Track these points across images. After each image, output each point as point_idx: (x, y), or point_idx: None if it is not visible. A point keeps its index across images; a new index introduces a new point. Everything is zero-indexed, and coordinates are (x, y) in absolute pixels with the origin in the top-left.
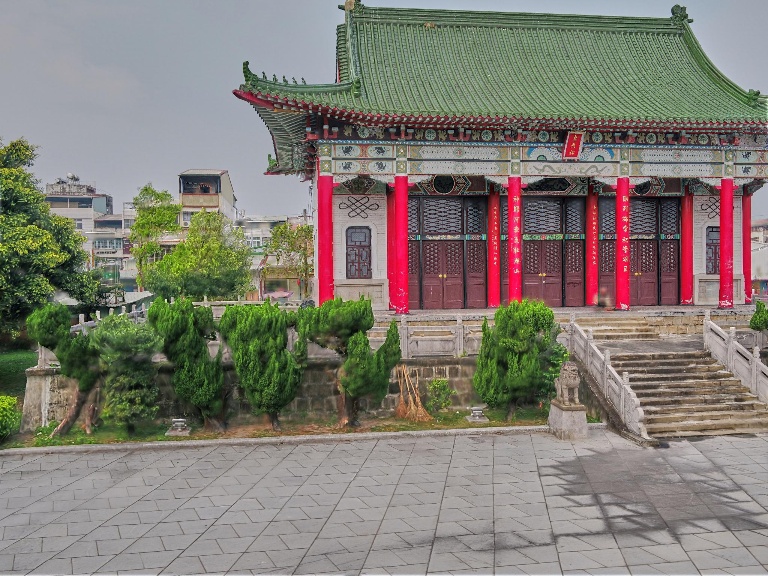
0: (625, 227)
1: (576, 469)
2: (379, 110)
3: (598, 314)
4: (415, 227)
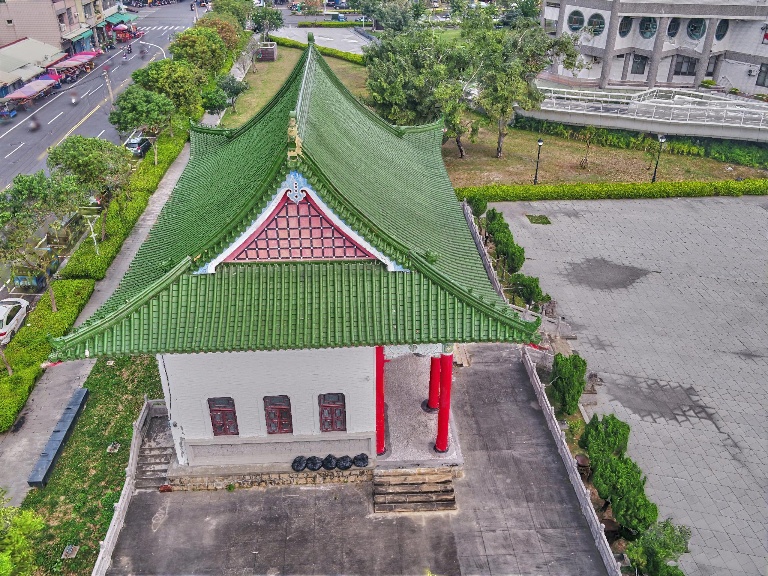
0: None
1: (643, 411)
2: None
3: None
4: None
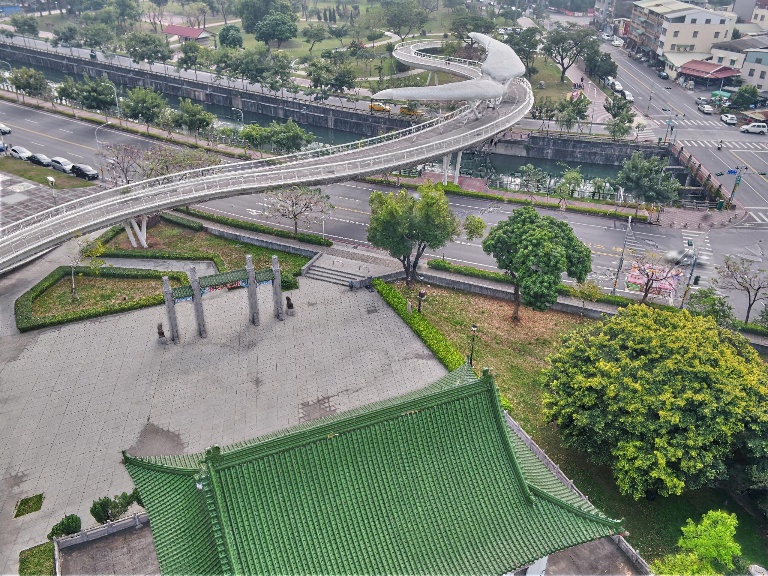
0: None
1: None
2: (418, 390)
3: None
4: None
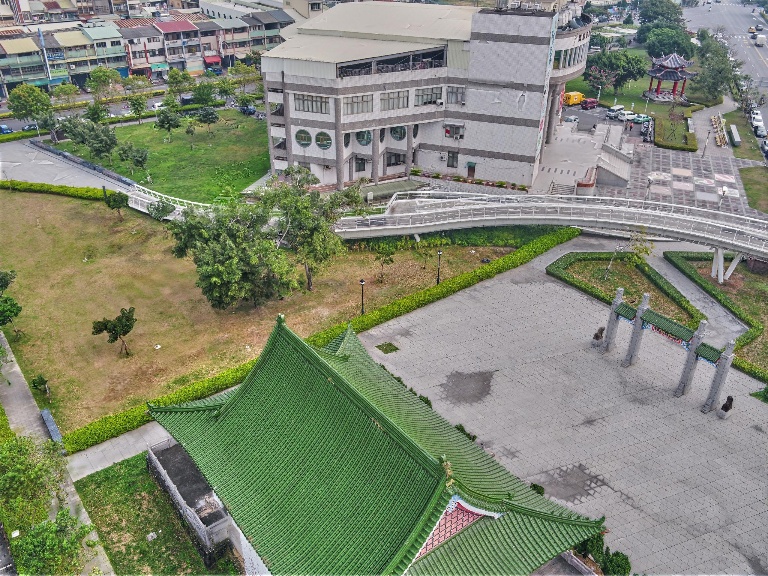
0: None
1: (571, 497)
2: None
3: None
4: None
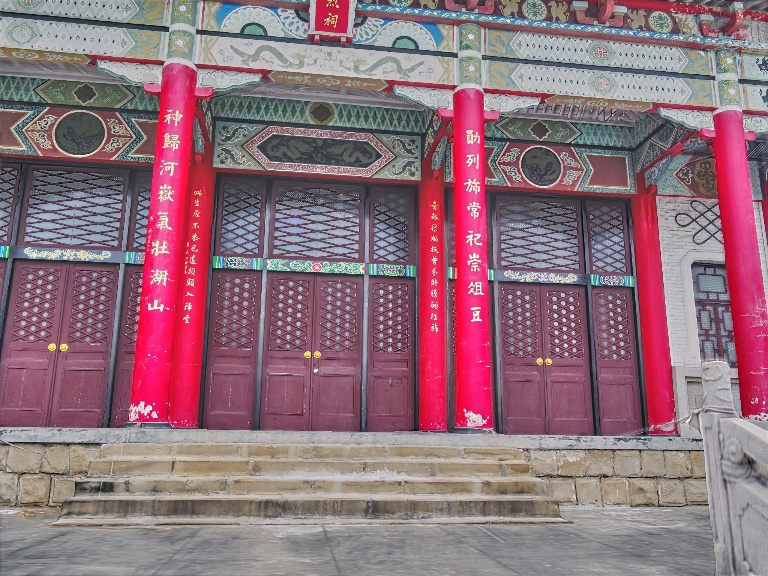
0: (473, 206)
1: None
2: None
3: (381, 435)
4: (2, 229)
